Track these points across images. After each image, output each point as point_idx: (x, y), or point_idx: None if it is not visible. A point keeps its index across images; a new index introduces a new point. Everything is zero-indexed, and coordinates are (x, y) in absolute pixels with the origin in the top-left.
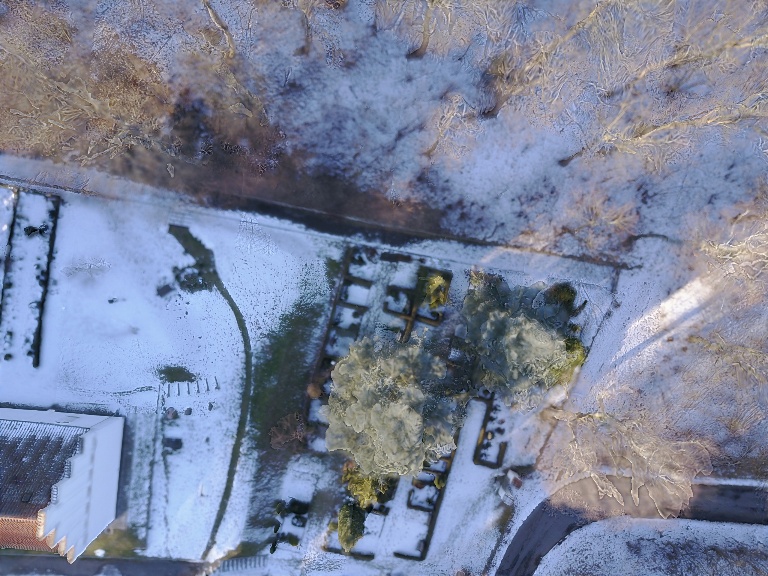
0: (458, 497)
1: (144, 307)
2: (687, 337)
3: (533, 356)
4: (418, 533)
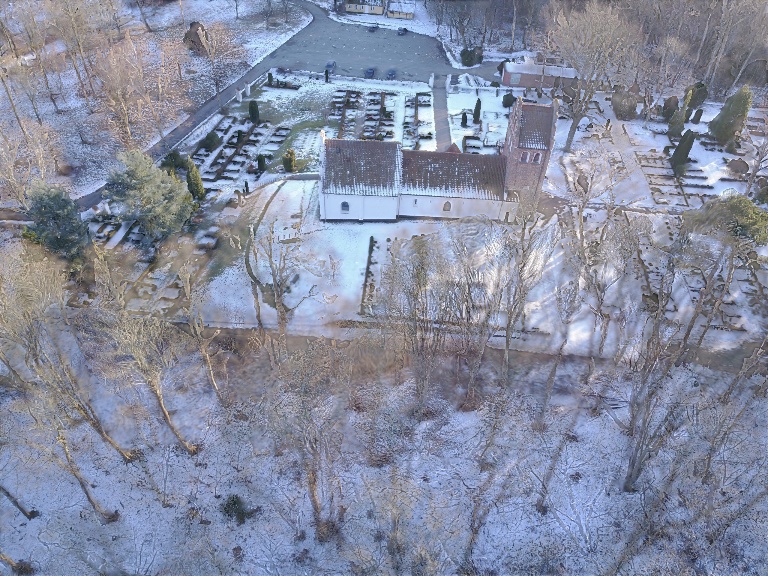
0: None
1: None
2: None
3: None
4: None
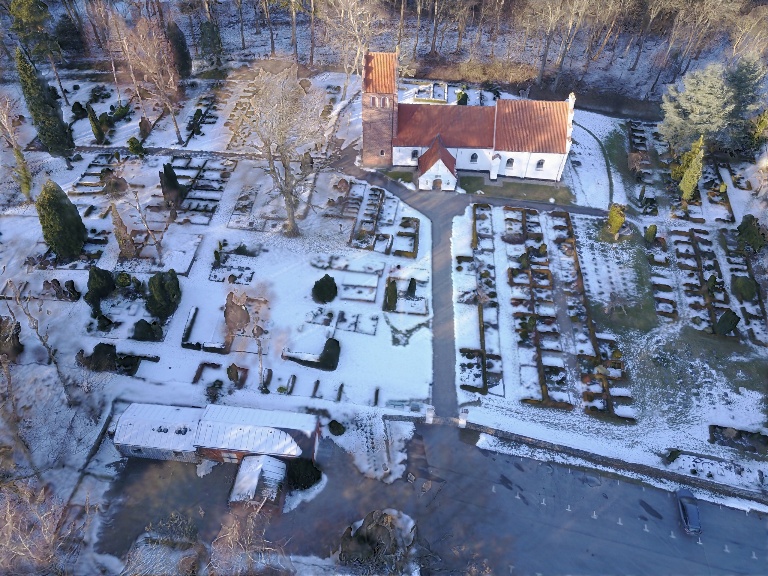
0: (736, 200)
1: None
2: None
3: (752, 61)
4: (724, 213)
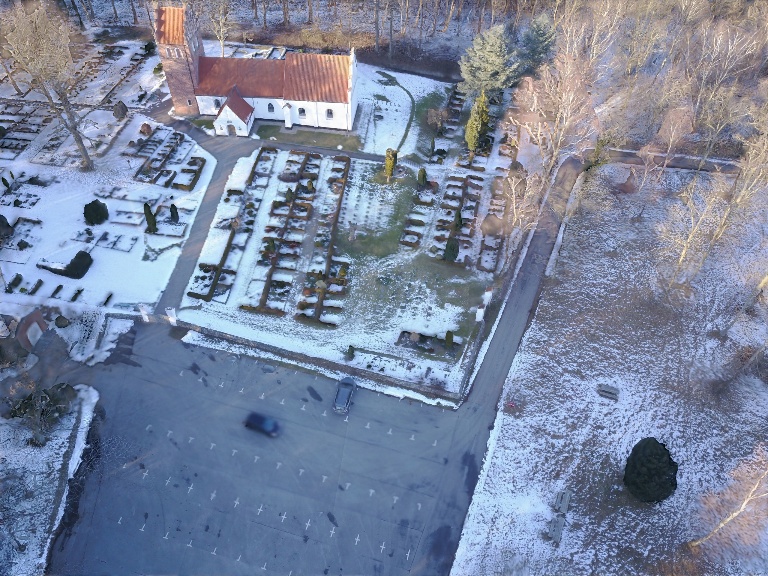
0: (525, 153)
1: (368, 80)
2: (620, 106)
3: (542, 24)
4: None
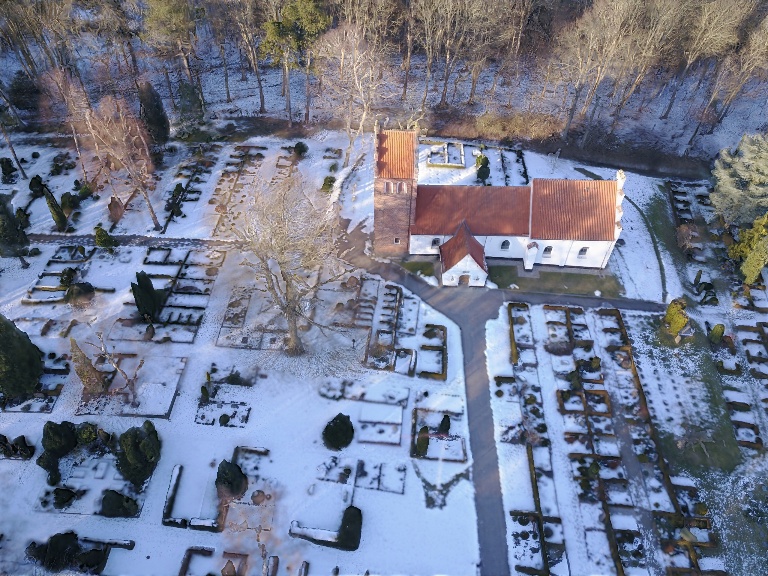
0: None
1: None
2: None
3: None
4: None
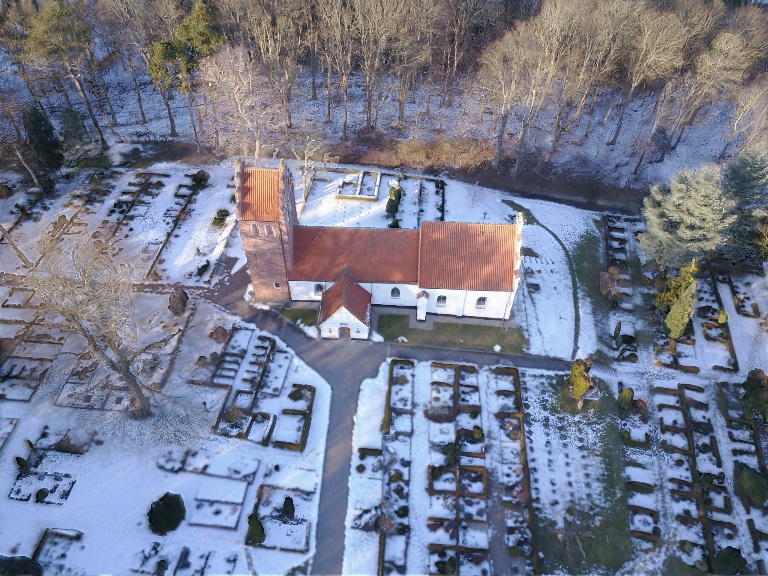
0: (740, 334)
1: (501, 222)
2: None
3: (758, 156)
4: (724, 356)
